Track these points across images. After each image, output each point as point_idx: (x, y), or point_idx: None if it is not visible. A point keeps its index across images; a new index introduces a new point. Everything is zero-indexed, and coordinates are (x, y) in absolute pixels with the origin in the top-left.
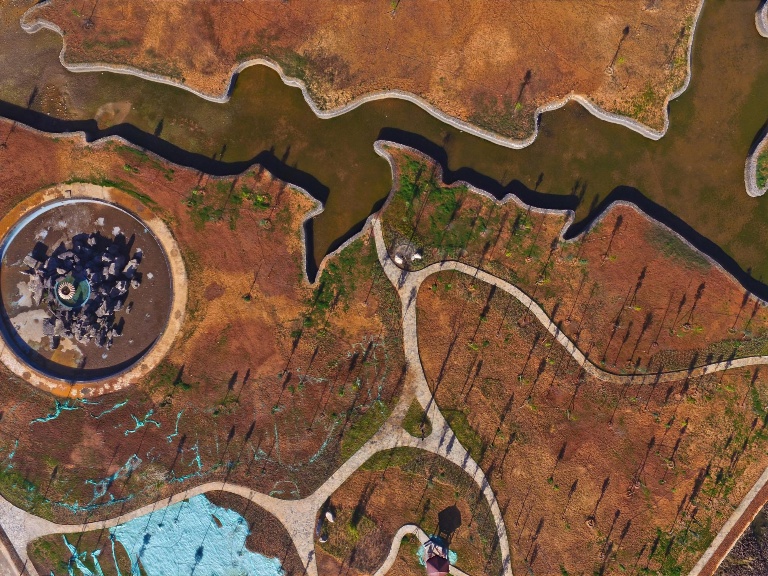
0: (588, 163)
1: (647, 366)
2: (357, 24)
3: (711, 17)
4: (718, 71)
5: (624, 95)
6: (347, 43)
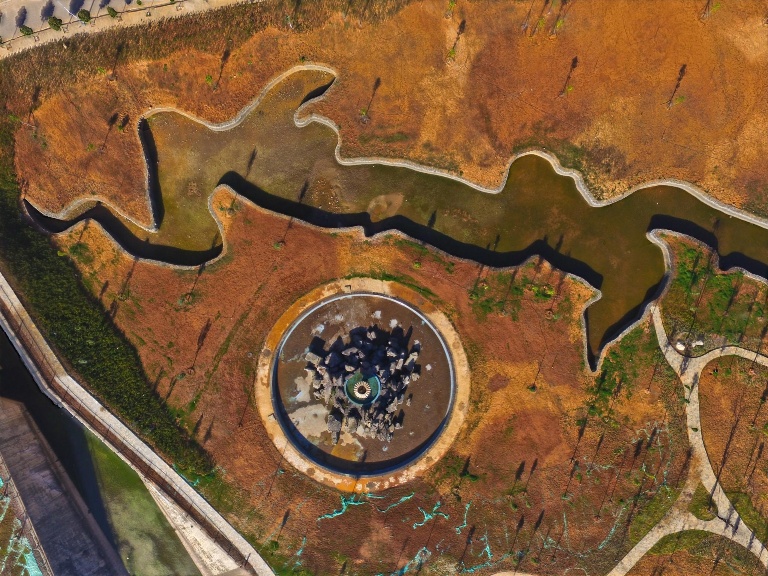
0: None
1: None
2: (633, 115)
3: None
4: None
5: None
6: (624, 134)
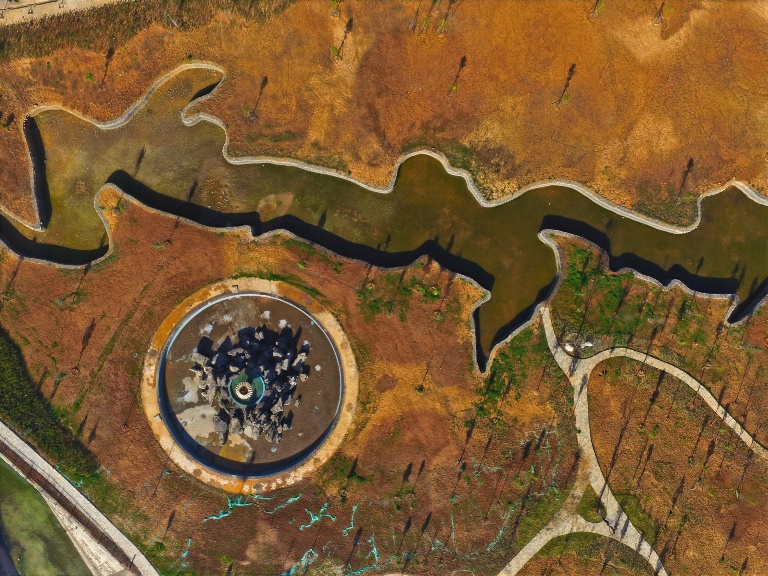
0: (747, 246)
1: None
2: (523, 115)
3: None
4: None
5: None
6: (513, 134)
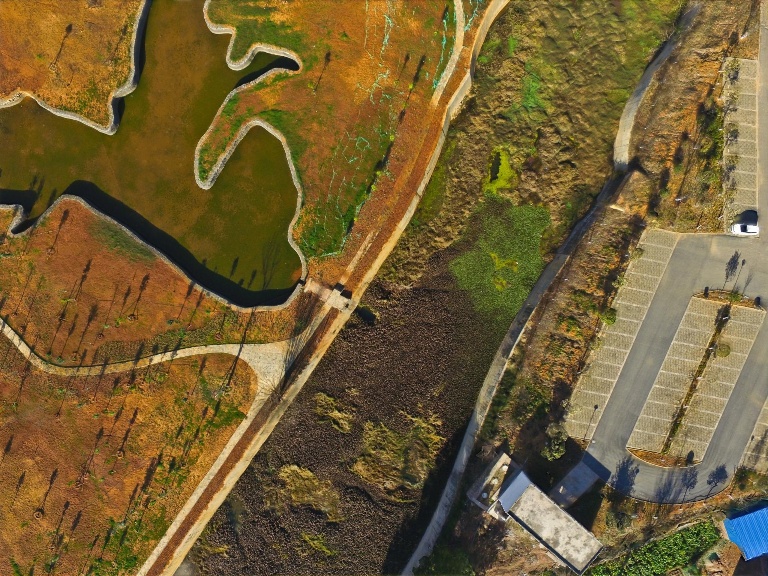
0: (46, 158)
1: (93, 357)
2: None
3: (164, 14)
4: (171, 67)
5: (69, 91)
6: None
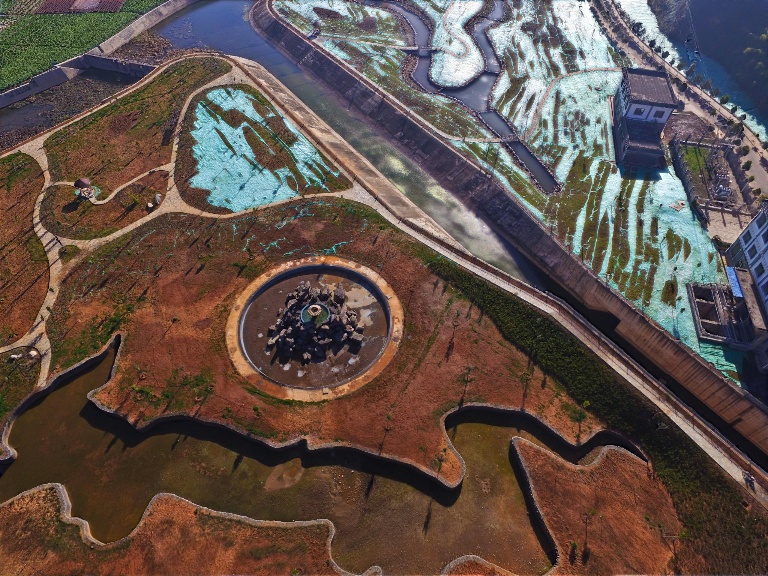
0: None
1: None
2: None
3: None
4: None
5: None
6: None
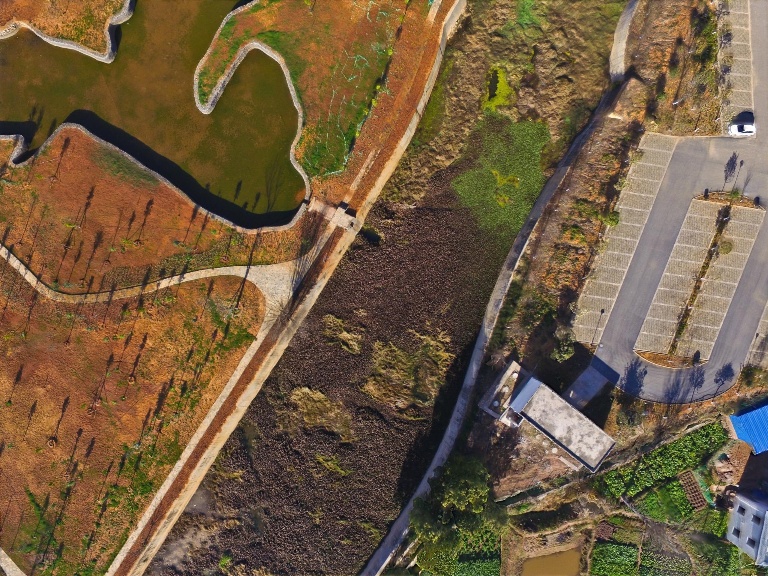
0: (44, 89)
1: (100, 284)
2: None
3: None
4: None
5: (65, 19)
6: None
